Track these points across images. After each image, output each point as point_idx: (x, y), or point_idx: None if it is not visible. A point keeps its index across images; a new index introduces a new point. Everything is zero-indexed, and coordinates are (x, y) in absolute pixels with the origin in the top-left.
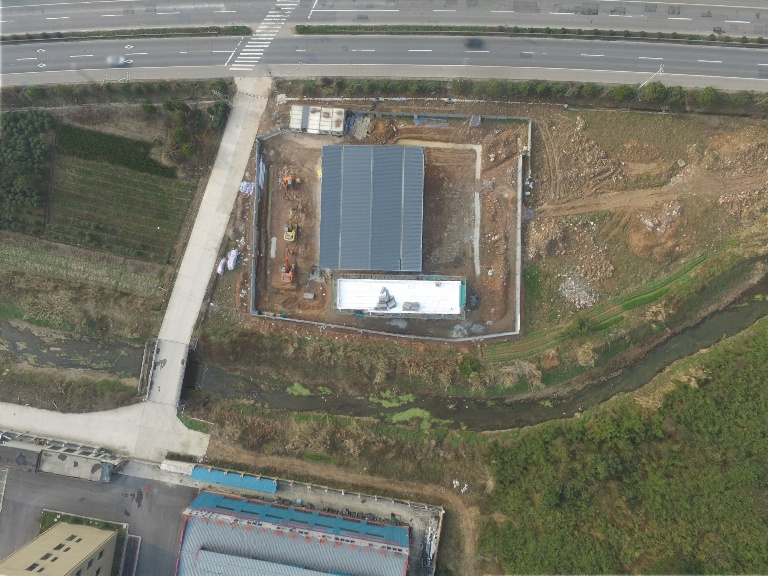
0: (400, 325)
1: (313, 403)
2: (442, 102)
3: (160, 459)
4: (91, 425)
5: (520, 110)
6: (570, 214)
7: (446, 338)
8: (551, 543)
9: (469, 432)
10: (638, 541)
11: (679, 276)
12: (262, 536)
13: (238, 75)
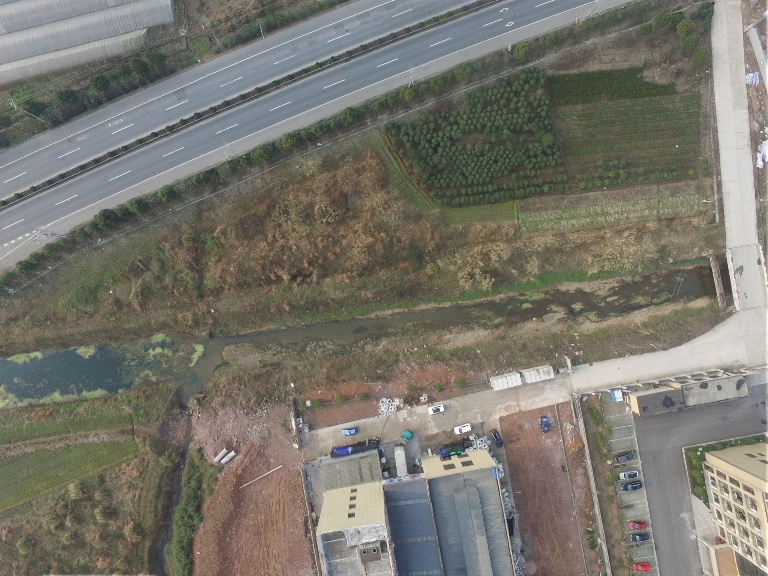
0: None
1: None
2: None
3: None
4: (696, 352)
5: None
6: None
7: None
8: None
9: None
10: None
11: None
12: None
13: None
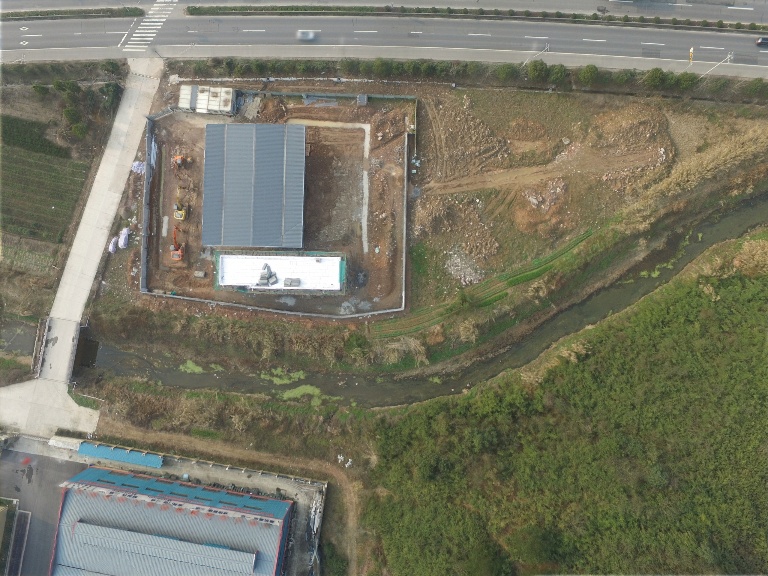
0: (289, 302)
1: (206, 380)
2: (332, 82)
3: (50, 435)
4: None
5: (408, 89)
6: (456, 192)
7: (333, 315)
8: (424, 515)
9: (358, 408)
10: (505, 511)
11: (564, 253)
12: (141, 509)
13: (131, 56)
